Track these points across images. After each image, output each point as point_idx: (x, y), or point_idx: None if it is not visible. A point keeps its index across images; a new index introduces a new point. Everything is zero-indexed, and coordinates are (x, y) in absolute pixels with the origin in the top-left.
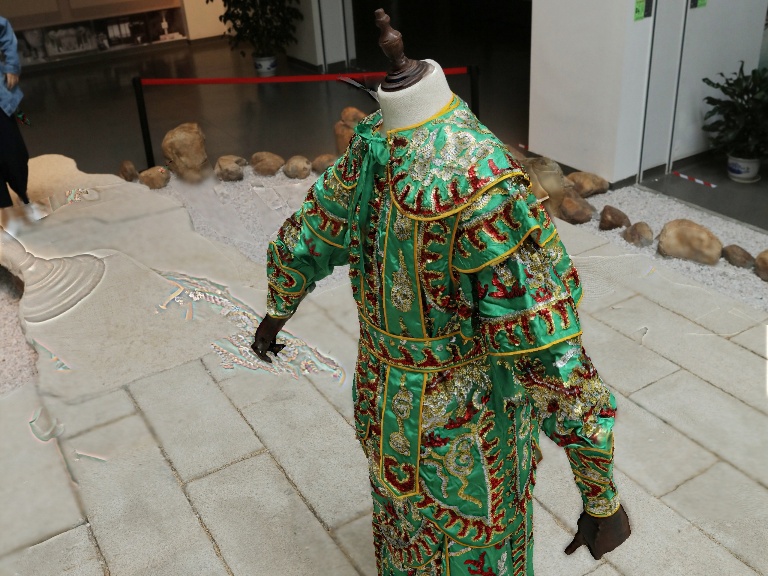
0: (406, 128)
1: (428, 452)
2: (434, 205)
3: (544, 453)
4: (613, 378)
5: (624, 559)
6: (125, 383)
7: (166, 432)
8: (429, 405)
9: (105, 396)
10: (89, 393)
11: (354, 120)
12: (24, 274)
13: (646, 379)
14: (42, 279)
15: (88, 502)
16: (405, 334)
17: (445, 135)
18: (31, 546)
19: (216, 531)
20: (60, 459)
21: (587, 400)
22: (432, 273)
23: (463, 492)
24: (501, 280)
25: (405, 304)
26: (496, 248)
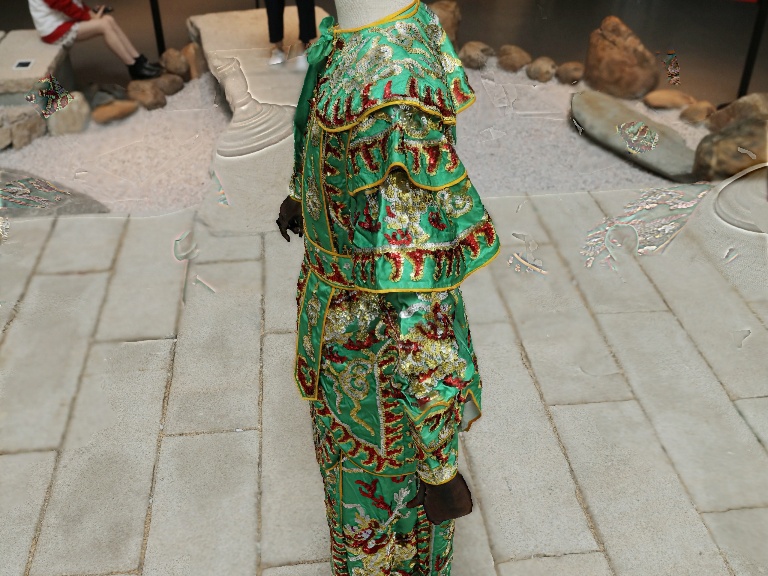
0: (347, 30)
1: (327, 364)
2: (333, 116)
3: (605, 424)
4: (729, 376)
5: (623, 556)
6: (264, 231)
7: (274, 284)
8: (332, 319)
9: (243, 237)
10: (232, 230)
11: (613, 31)
12: (236, 111)
13: (767, 389)
14: (247, 119)
15: (184, 322)
16: (319, 243)
17: (370, 45)
18: (126, 341)
19: (268, 383)
20: (182, 279)
21: (422, 360)
22: (331, 187)
23: (356, 414)
24: (371, 211)
25: (315, 212)
26: (366, 176)
